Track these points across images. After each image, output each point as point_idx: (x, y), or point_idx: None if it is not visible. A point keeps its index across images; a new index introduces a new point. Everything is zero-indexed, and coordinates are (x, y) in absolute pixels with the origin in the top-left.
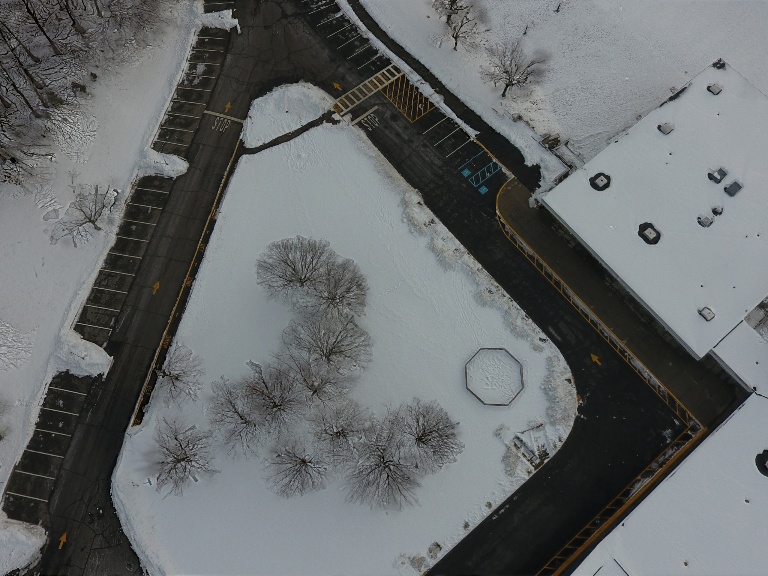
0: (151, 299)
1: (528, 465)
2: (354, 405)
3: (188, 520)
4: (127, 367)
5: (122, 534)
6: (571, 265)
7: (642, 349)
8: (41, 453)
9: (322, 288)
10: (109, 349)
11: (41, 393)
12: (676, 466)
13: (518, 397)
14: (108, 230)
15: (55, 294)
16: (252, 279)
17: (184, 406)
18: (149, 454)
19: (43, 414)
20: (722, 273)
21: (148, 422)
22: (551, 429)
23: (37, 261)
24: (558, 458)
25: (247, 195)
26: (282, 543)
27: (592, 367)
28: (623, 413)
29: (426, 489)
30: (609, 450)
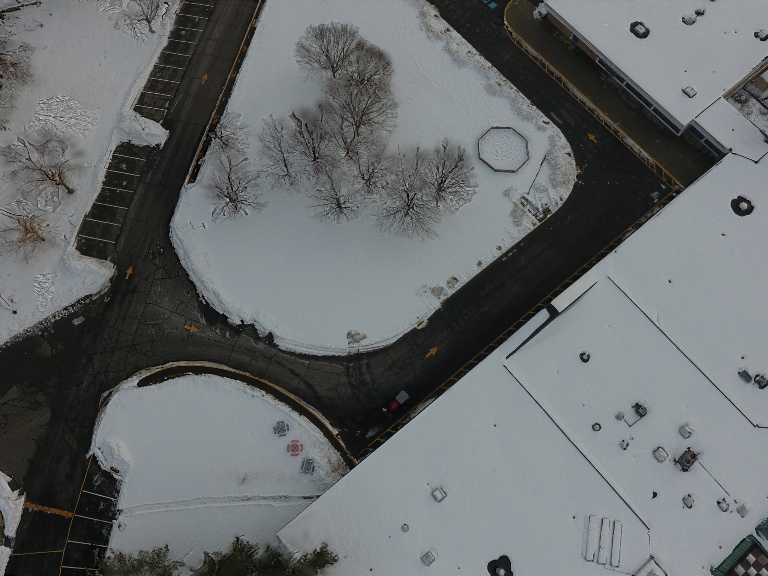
0: (200, 87)
1: (533, 218)
2: (382, 158)
3: (238, 256)
4: (181, 139)
5: (180, 267)
6: (571, 64)
7: (633, 129)
8: (108, 205)
9: (353, 69)
10: (165, 125)
11: (107, 158)
12: (662, 208)
13: (524, 166)
14: (161, 33)
15: (116, 81)
16: (289, 73)
17: (234, 157)
18: (203, 204)
19: (109, 175)
20: (703, 61)
21: (201, 180)
22: (553, 191)
23: (100, 53)
24: (559, 214)
25: (283, 8)
26: (320, 275)
27: (589, 144)
28: (616, 179)
29: (444, 235)
30: (604, 208)
